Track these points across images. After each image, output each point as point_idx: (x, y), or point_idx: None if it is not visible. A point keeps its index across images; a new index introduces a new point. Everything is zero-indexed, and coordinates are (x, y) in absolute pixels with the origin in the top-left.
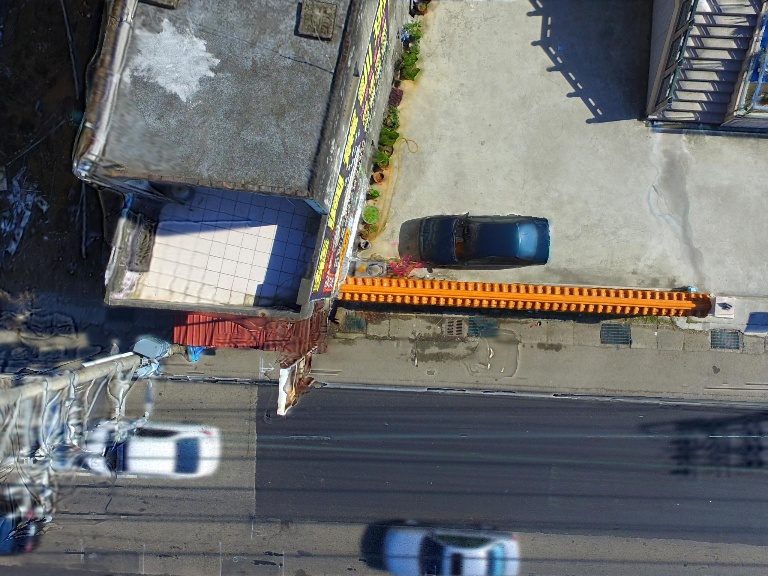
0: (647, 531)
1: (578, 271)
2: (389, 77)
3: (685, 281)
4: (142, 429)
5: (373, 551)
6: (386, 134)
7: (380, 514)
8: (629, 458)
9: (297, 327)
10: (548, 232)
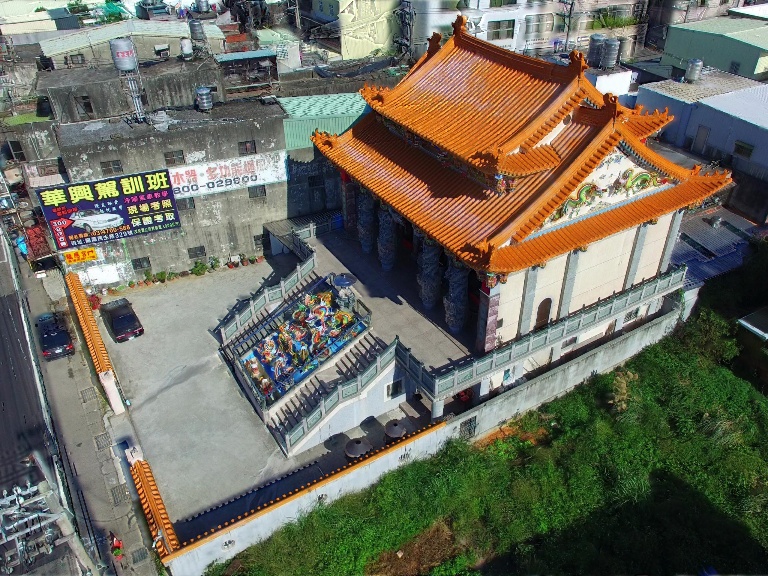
0: None
1: (122, 361)
2: (184, 257)
3: (134, 402)
4: None
5: None
6: (162, 273)
7: None
8: (2, 432)
9: (24, 189)
10: (134, 328)
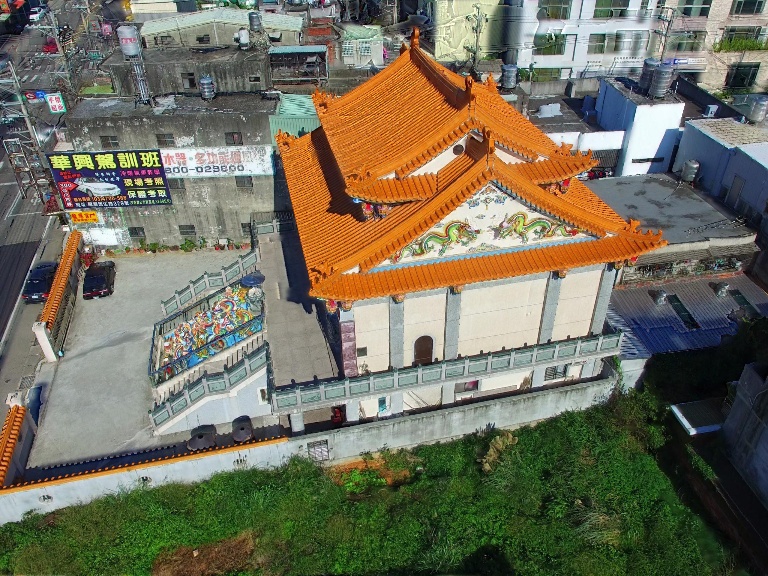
0: None
1: None
2: (176, 233)
3: None
4: (27, 218)
5: None
6: (155, 244)
7: None
8: None
9: None
10: (99, 289)
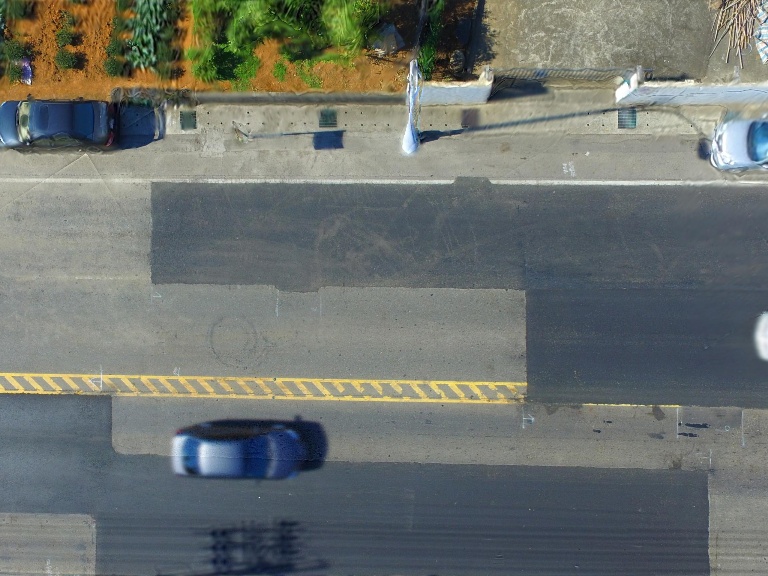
0: (319, 468)
1: None
2: None
3: None
4: None
5: (587, 441)
6: None
7: (581, 477)
8: (339, 537)
9: None
10: None
